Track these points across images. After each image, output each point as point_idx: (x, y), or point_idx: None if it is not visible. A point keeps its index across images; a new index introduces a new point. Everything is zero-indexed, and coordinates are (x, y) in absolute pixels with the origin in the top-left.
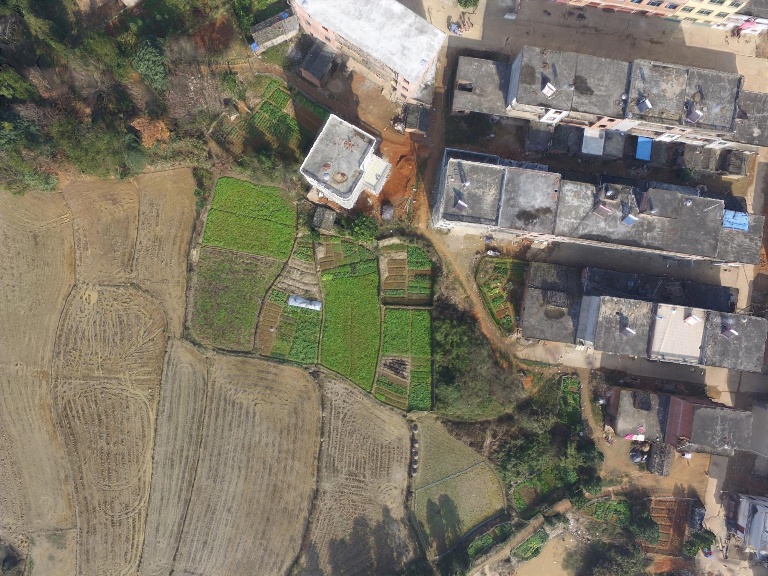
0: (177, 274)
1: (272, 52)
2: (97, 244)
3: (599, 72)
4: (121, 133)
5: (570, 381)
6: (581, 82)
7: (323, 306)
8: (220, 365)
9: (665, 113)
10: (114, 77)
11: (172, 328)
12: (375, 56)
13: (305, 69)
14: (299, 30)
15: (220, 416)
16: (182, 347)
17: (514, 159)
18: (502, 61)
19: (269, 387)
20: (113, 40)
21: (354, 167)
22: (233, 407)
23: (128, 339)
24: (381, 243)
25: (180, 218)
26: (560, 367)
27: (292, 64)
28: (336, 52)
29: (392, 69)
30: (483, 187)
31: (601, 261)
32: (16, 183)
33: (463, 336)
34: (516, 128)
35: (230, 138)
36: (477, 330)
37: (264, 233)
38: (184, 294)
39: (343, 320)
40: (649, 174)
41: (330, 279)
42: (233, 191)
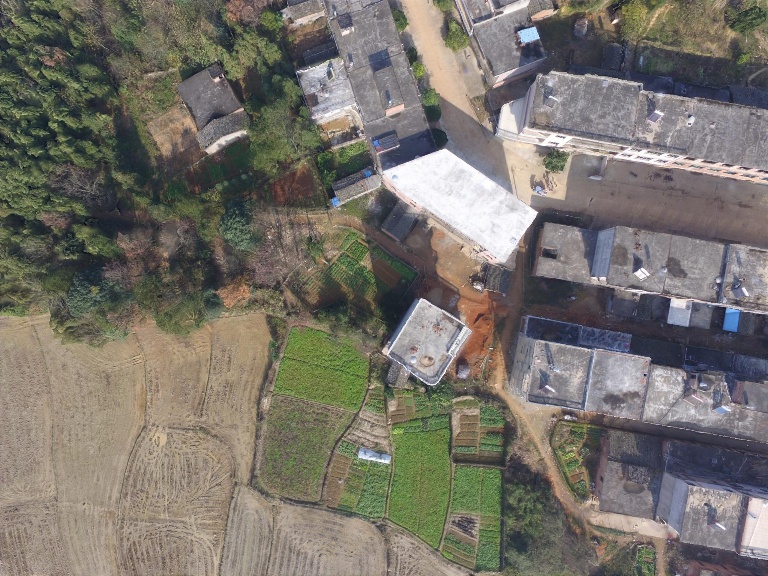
0: (247, 420)
1: (352, 205)
2: (168, 386)
3: (693, 254)
4: (198, 280)
5: (645, 550)
6: (674, 264)
7: (393, 460)
8: (286, 514)
9: (761, 299)
10: (197, 233)
11: (239, 474)
12: (464, 233)
13: (387, 230)
14: (381, 186)
15: (284, 565)
16: (249, 493)
17: (594, 322)
18: (585, 222)
19: (335, 538)
20: (198, 198)
21: (442, 351)
22: (298, 557)
23: (195, 483)
24: (455, 400)
25: (252, 363)
26: (635, 536)
27: (371, 217)
28: (419, 213)
29: (480, 245)
30: (570, 369)
31: (681, 429)
32: (97, 337)
33: (537, 503)
34: (597, 290)
35: (306, 288)
36: (552, 497)
37: (336, 383)
38: (253, 440)
39: (413, 475)
40: (734, 341)
41: (401, 433)
42: (306, 340)
